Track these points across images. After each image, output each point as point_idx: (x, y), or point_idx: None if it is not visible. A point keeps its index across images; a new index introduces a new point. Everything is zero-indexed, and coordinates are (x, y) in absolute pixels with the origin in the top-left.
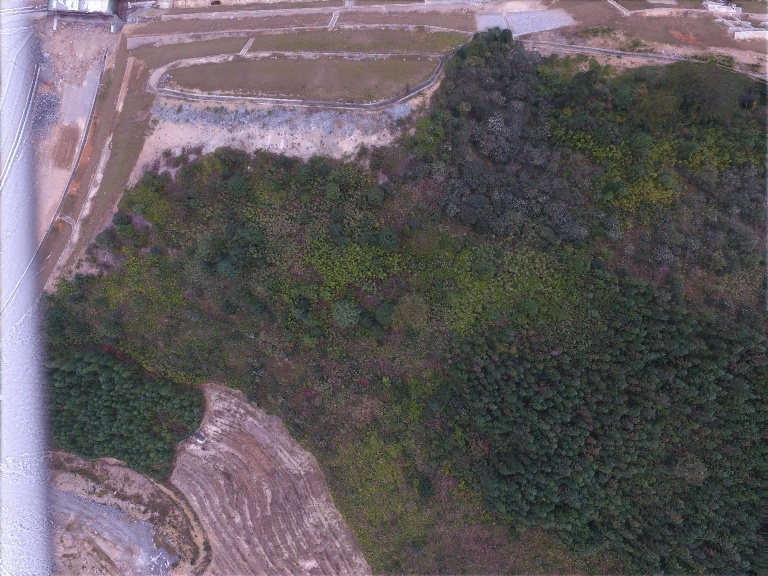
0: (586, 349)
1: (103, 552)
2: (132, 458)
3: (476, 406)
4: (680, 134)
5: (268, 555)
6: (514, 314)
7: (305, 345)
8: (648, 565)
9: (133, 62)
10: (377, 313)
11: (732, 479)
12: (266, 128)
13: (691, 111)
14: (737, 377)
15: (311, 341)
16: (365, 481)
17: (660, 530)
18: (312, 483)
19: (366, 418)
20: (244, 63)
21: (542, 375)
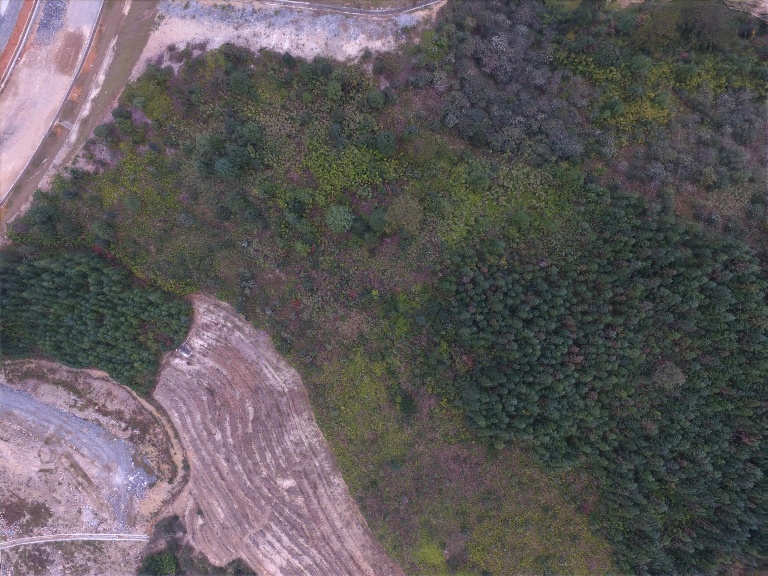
0: (574, 261)
1: (80, 468)
2: (116, 368)
3: (463, 317)
4: (679, 58)
5: (246, 473)
6: (506, 227)
7: (297, 255)
8: (622, 478)
9: None
10: (371, 218)
11: (709, 389)
12: (272, 27)
13: (691, 36)
14: (720, 285)
15: (303, 248)
16: (348, 399)
17: (636, 442)
18: (295, 400)
19: (353, 334)
20: None
21: (530, 286)
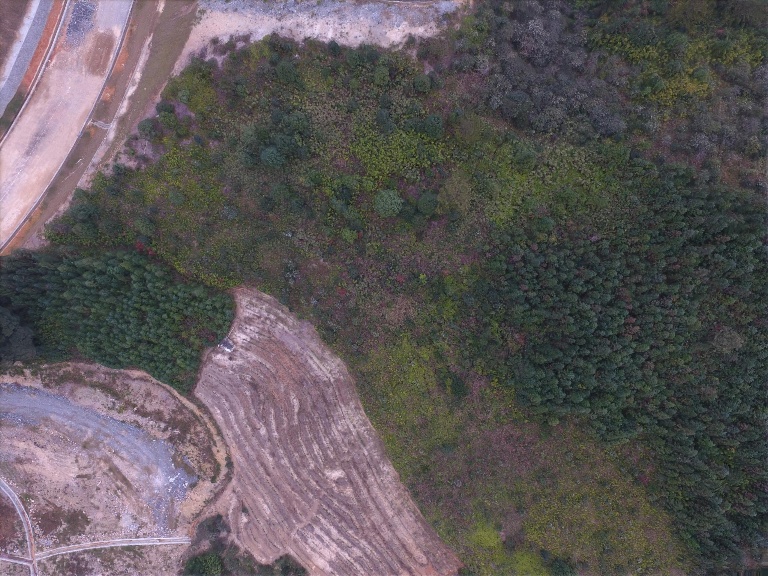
0: (625, 234)
1: (119, 472)
2: (157, 366)
3: (515, 295)
4: (714, 34)
5: (294, 466)
6: (553, 205)
7: (343, 242)
8: (682, 445)
9: None
10: (420, 201)
11: (766, 352)
12: (315, 17)
13: (724, 14)
14: None
15: (350, 235)
16: (396, 385)
17: (695, 408)
18: (341, 390)
19: (399, 320)
20: None
21: (581, 261)
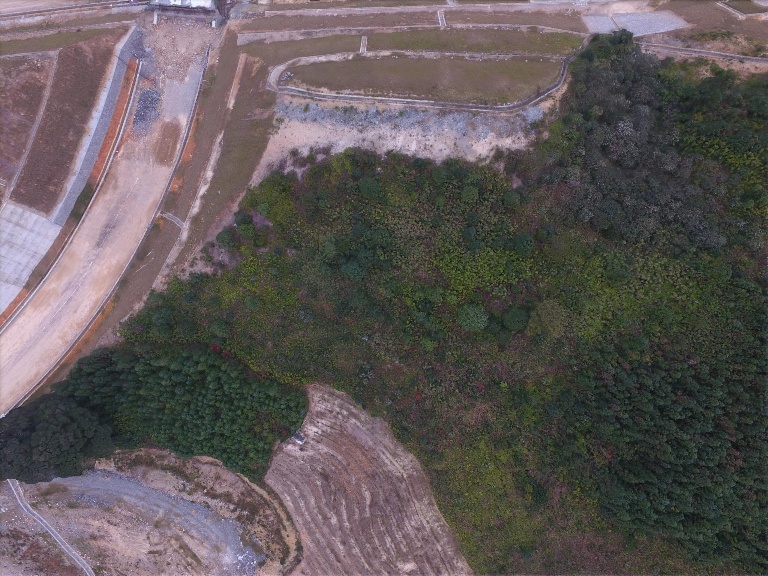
0: (726, 359)
1: (189, 549)
2: (230, 457)
3: (604, 414)
4: None
5: (365, 557)
6: (646, 322)
7: (421, 348)
8: None
9: (245, 59)
10: (507, 318)
11: None
12: (398, 129)
13: None
14: None
15: (431, 345)
16: (471, 485)
17: None
18: (415, 486)
19: (476, 422)
20: (365, 62)
21: (677, 384)
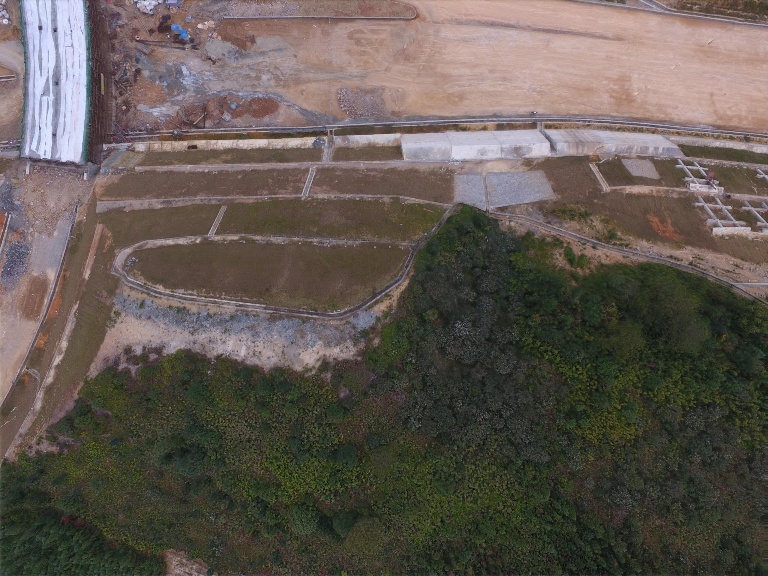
0: None
1: None
2: None
3: None
4: (646, 364)
5: None
6: (472, 532)
7: None
8: None
9: (101, 229)
10: (334, 525)
11: None
12: (228, 333)
13: None
14: None
15: (269, 535)
16: None
17: None
18: None
19: None
20: (211, 247)
21: None
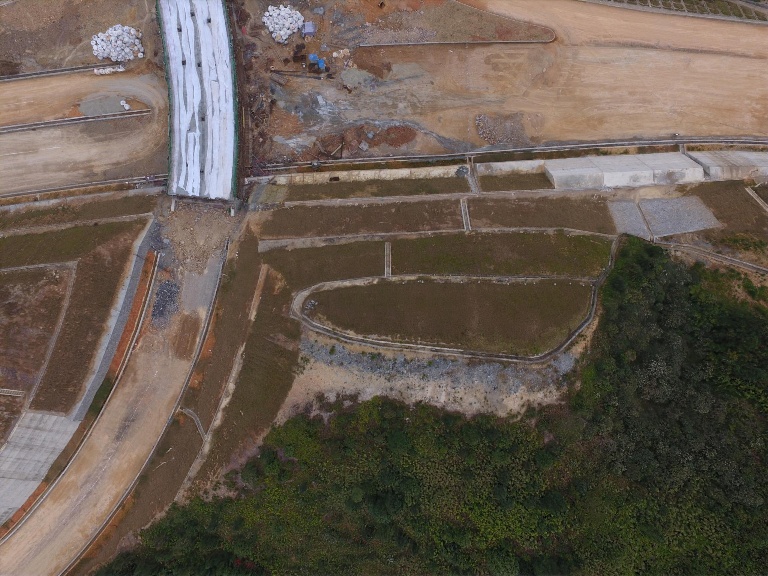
0: None
1: None
2: None
3: None
4: None
5: None
6: None
7: (447, 575)
8: None
9: (267, 270)
10: (538, 571)
11: None
12: (426, 379)
13: None
14: None
15: None
16: None
17: None
18: None
19: None
20: (390, 288)
21: None
